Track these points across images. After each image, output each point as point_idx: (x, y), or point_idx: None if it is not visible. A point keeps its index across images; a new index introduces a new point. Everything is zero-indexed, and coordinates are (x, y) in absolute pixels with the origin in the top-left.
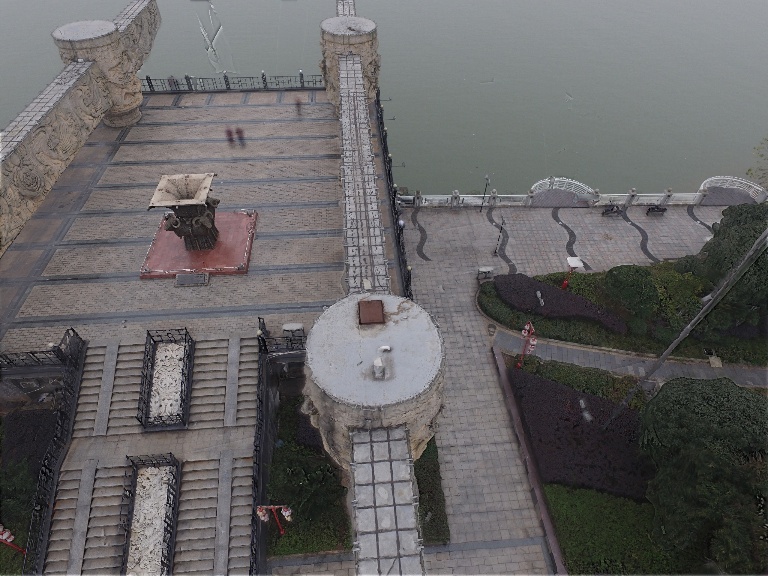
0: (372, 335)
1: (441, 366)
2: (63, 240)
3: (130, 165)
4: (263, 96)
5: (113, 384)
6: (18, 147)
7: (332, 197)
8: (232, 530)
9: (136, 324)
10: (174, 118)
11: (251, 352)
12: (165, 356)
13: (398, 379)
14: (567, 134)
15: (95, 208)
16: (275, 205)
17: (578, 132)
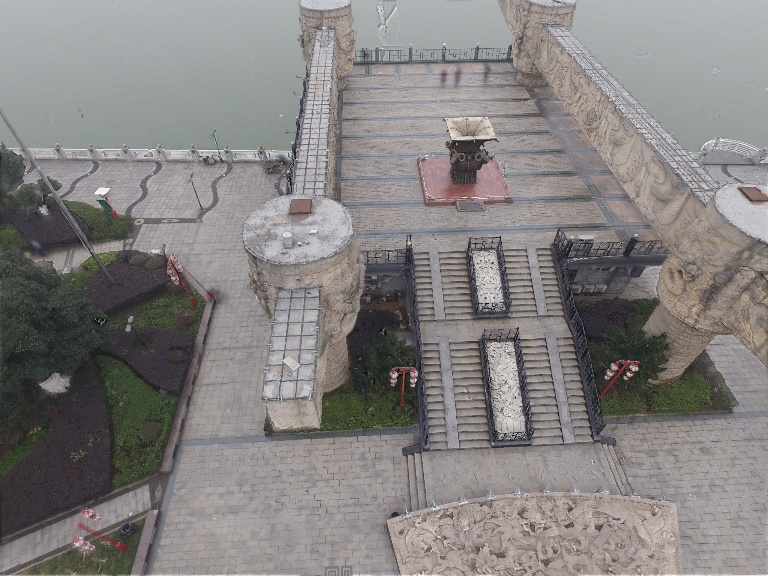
0: (766, 208)
1: None
2: (342, 176)
3: (361, 120)
4: (443, 67)
5: (441, 281)
6: None
7: (552, 146)
8: (567, 391)
9: (443, 237)
10: (375, 84)
11: (547, 259)
12: (480, 260)
13: None
14: (726, 101)
15: (353, 153)
16: (506, 152)
17: (736, 99)
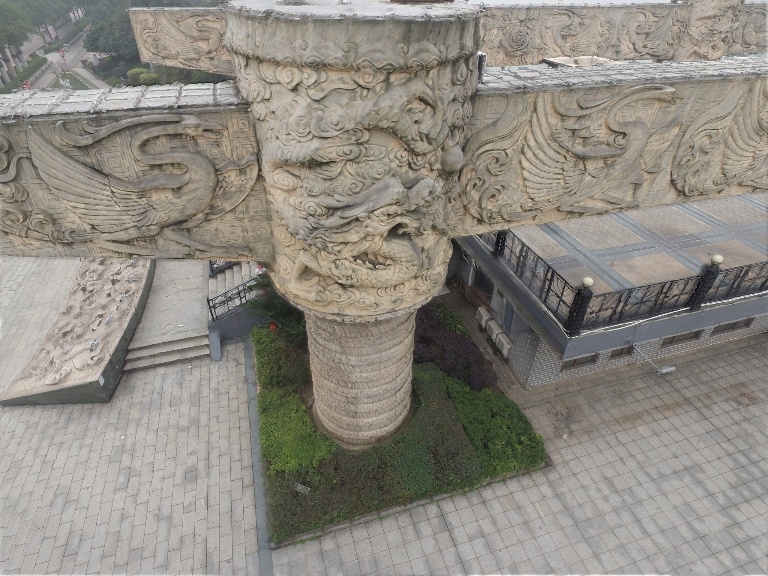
0: None
1: (321, 16)
2: None
3: None
4: None
5: None
6: (534, 9)
7: None
8: None
9: None
10: None
11: None
12: None
13: (282, 6)
14: None
15: None
16: None
17: None
